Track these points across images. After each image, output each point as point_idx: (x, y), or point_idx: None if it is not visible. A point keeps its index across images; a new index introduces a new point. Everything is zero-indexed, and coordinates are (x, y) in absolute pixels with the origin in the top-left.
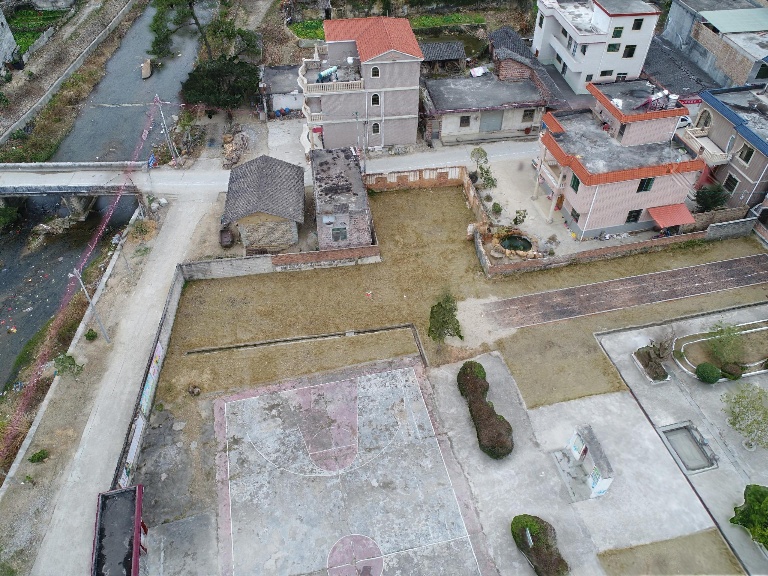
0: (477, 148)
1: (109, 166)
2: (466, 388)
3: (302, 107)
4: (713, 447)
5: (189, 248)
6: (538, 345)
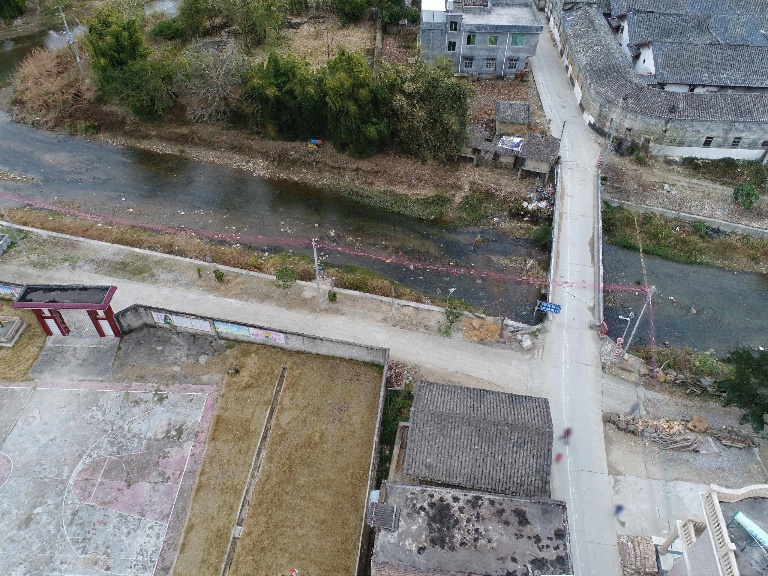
0: None
1: None
2: None
3: None
4: None
5: (439, 370)
6: None
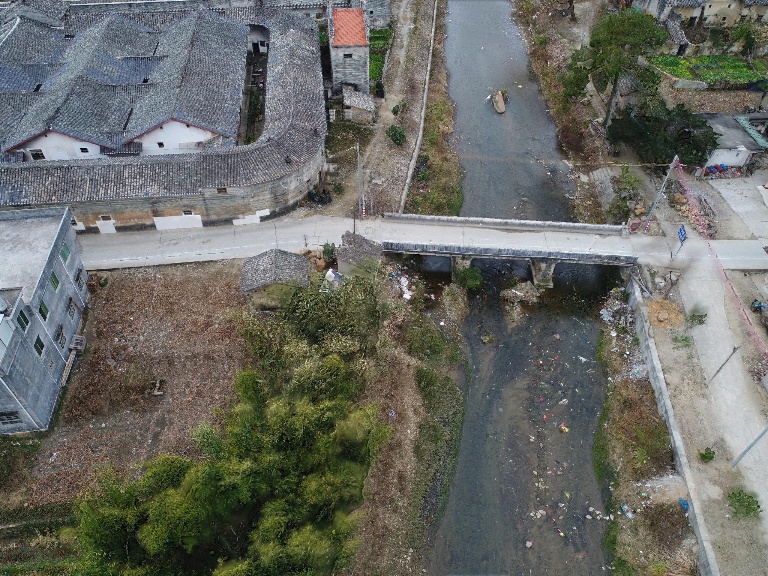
0: None
1: (582, 228)
2: None
3: None
4: None
5: (737, 341)
6: None
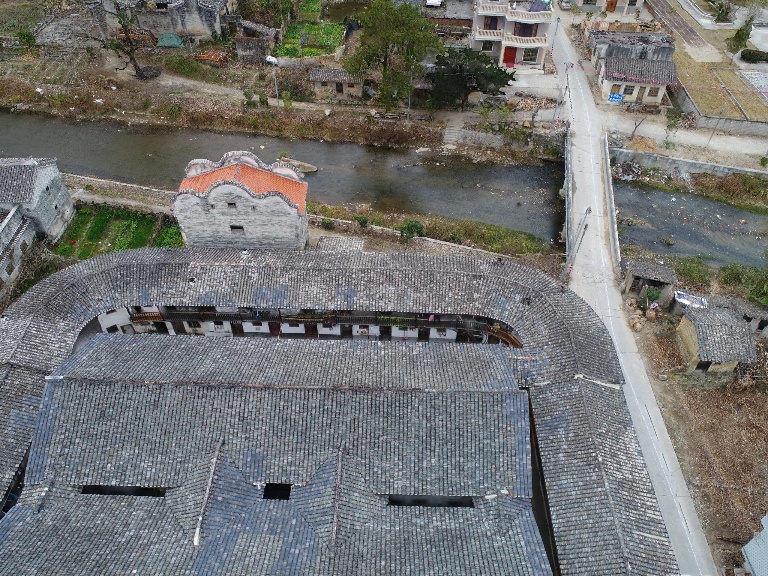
0: (574, 7)
1: None
2: (761, 55)
3: (522, 45)
4: (763, 22)
5: (663, 126)
6: (717, 41)
